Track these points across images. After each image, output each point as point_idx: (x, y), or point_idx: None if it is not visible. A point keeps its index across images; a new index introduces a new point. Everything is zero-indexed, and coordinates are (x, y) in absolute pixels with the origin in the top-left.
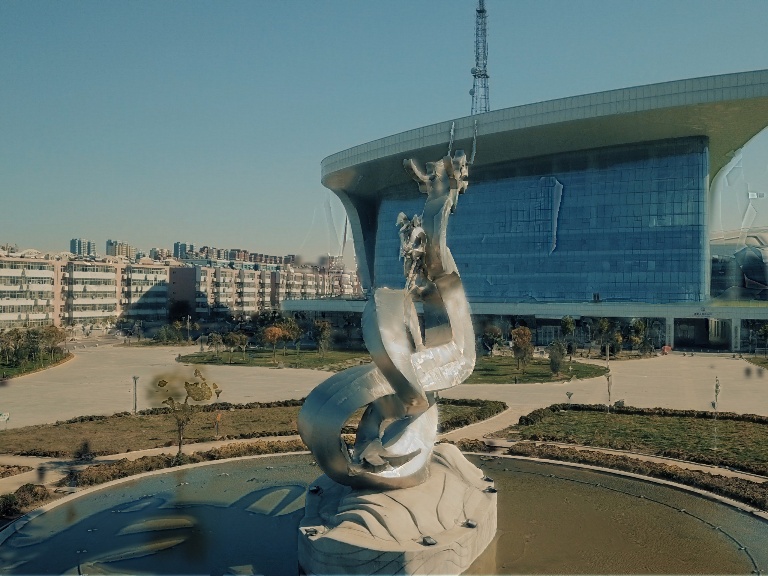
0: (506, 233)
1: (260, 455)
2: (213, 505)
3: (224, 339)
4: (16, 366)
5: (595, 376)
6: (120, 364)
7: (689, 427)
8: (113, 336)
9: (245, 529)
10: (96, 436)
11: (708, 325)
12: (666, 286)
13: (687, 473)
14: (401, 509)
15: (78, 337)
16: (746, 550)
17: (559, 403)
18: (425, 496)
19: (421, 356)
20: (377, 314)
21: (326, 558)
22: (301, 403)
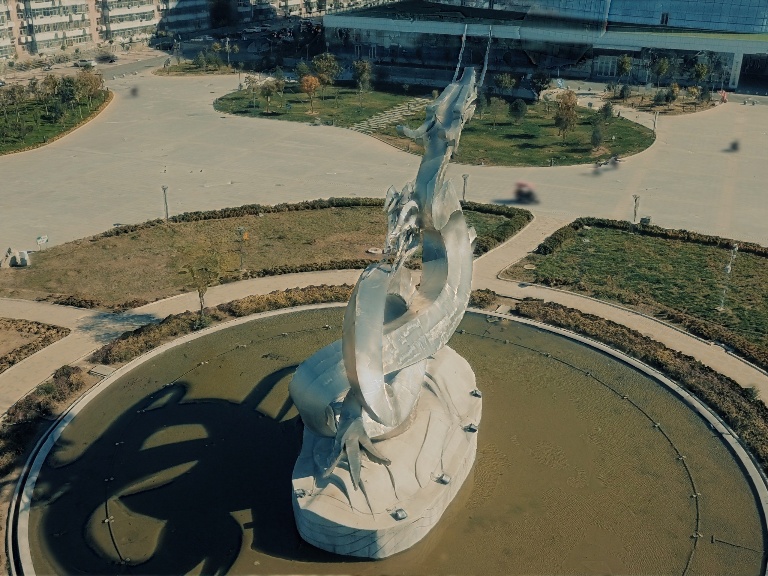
0: (554, 7)
1: (278, 311)
2: (228, 400)
3: (262, 76)
4: (56, 120)
5: (637, 151)
6: (158, 113)
7: (706, 265)
8: (153, 52)
9: (254, 435)
10: (129, 264)
11: None
12: (744, 10)
13: (677, 365)
14: (382, 470)
15: (118, 53)
16: (697, 499)
17: (584, 216)
18: (407, 448)
19: (407, 328)
20: (355, 330)
21: (311, 526)
22: (328, 205)
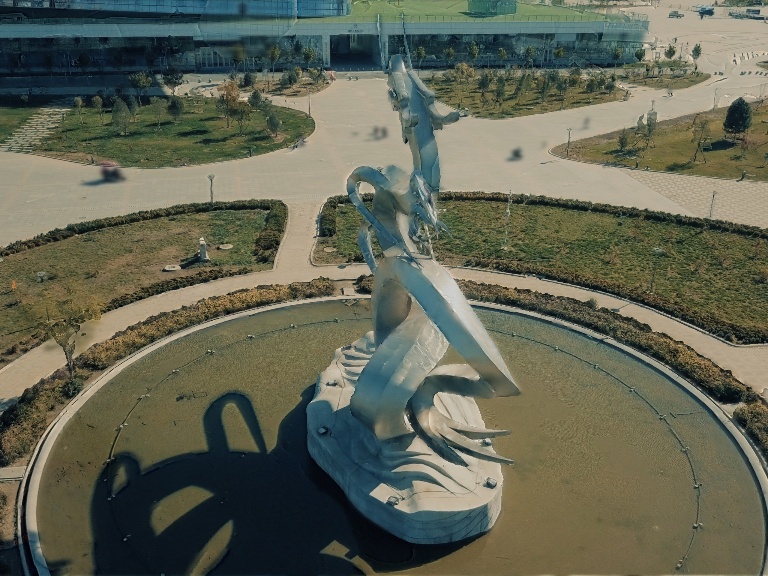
0: None
1: (144, 352)
2: (191, 453)
3: None
4: None
5: (310, 132)
6: None
7: (461, 216)
8: None
9: (251, 476)
10: None
11: (349, 34)
12: None
13: (527, 298)
14: None
15: None
16: (636, 391)
17: (333, 196)
18: None
19: None
20: (459, 316)
21: (425, 525)
22: (71, 233)
